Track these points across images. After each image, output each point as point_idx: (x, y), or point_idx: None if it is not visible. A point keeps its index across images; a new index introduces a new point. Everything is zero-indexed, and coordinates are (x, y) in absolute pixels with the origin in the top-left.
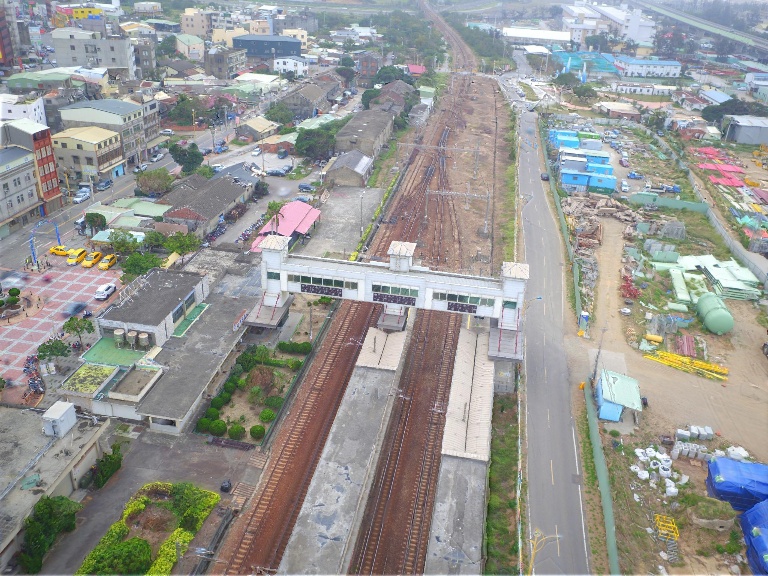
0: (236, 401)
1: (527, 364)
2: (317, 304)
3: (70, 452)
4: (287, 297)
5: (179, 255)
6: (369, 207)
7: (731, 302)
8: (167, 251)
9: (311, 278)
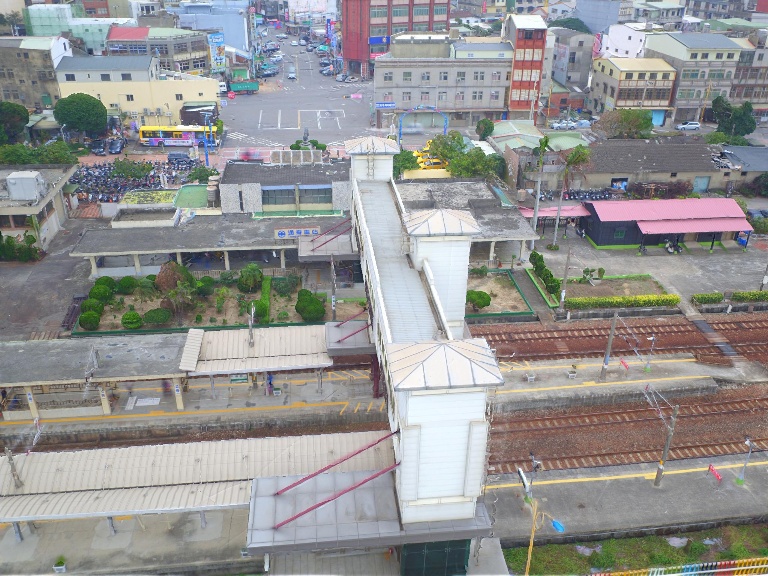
0: None
1: None
2: None
3: None
4: None
5: None
6: None
7: None
8: (493, 182)
9: None
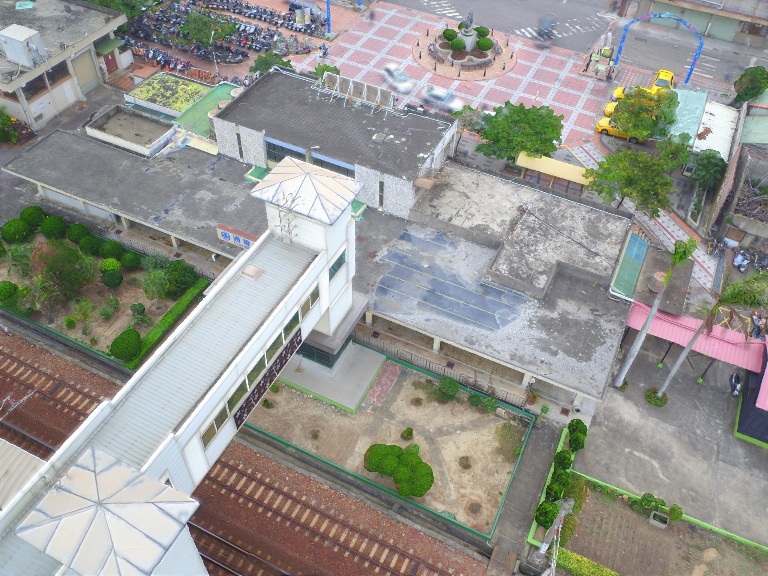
0: None
1: None
2: None
3: None
4: (322, 329)
5: None
6: None
7: None
8: (687, 199)
9: None
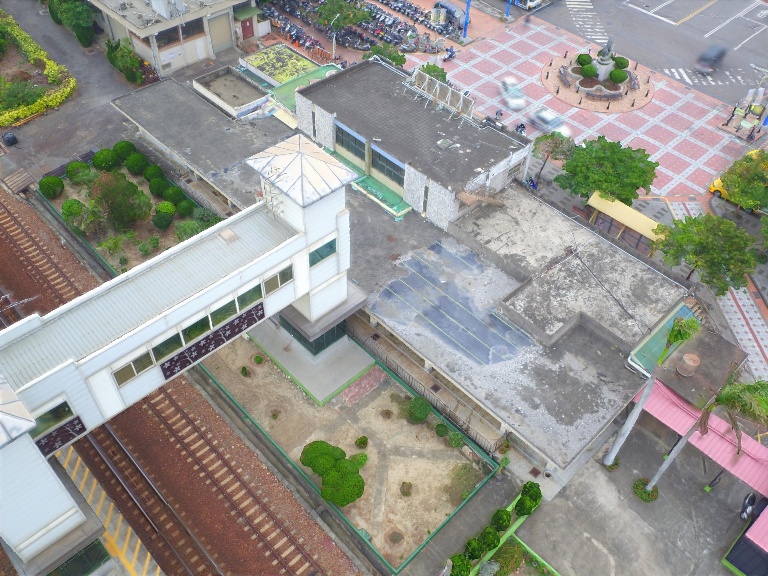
0: None
1: None
2: (352, 460)
3: (124, 9)
4: None
5: None
6: None
7: None
8: None
9: None
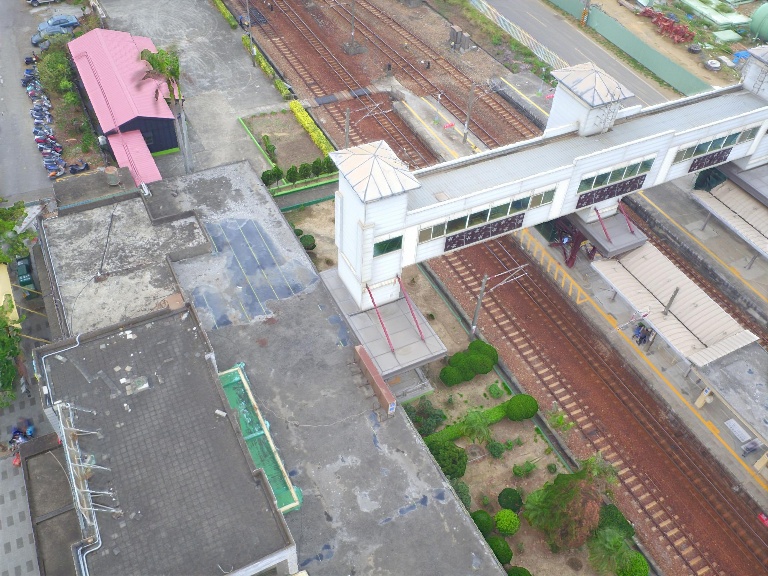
0: (529, 568)
1: None
2: None
3: None
4: None
5: (3, 265)
6: (194, 2)
7: (747, 9)
8: None
9: (467, 217)
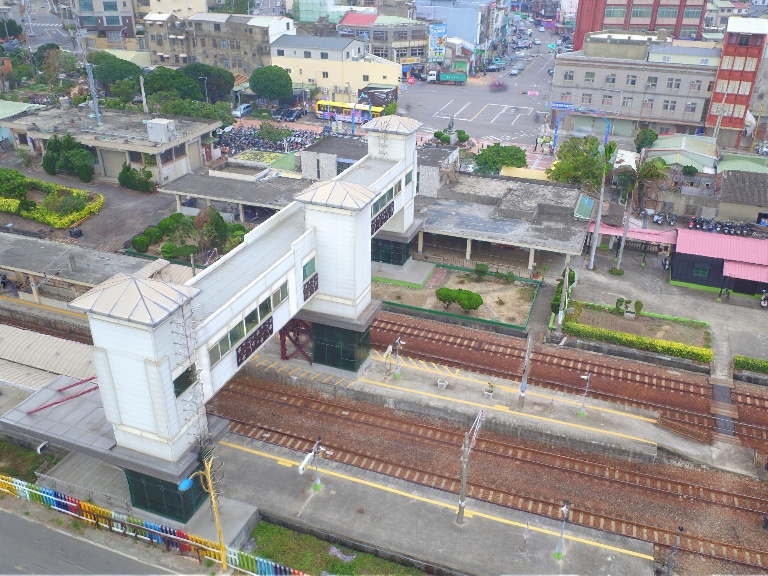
0: None
1: (117, 554)
2: None
3: None
4: (398, 230)
5: None
6: None
7: None
8: (616, 196)
9: None
